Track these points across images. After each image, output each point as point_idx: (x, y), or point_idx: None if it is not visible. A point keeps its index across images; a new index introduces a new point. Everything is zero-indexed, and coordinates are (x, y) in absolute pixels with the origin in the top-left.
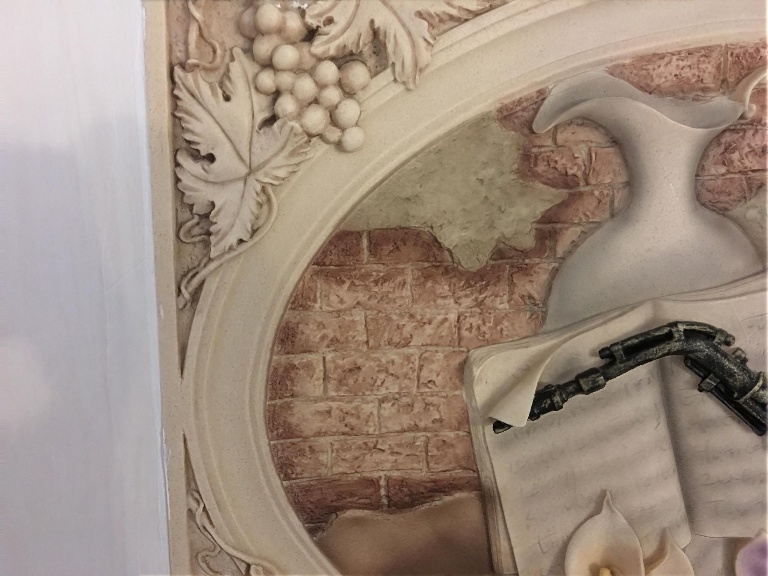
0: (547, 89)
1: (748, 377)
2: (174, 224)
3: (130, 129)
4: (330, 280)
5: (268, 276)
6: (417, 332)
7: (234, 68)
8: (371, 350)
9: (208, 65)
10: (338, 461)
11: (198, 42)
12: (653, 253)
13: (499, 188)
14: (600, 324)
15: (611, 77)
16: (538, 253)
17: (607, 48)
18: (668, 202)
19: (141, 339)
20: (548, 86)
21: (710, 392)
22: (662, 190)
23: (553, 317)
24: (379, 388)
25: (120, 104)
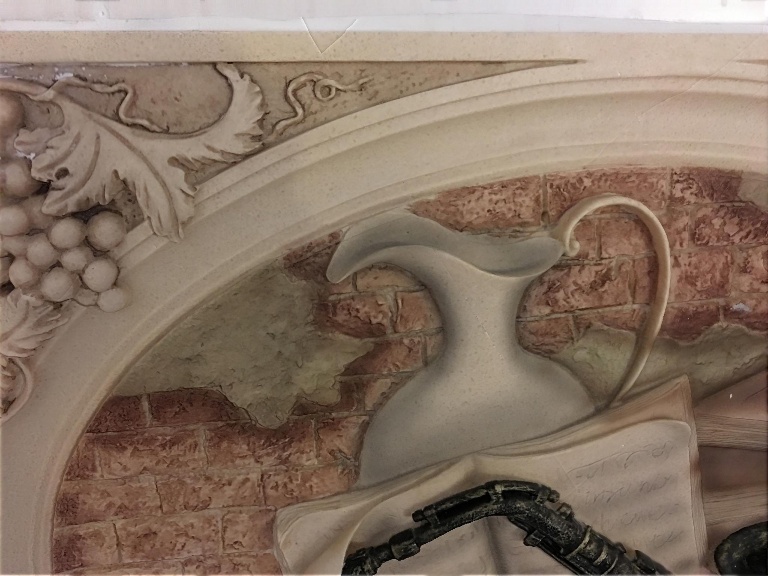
0: (341, 232)
1: (573, 535)
2: None
3: None
4: (109, 447)
5: (38, 444)
6: (216, 494)
7: None
8: (166, 515)
9: None
10: None
11: None
12: (470, 406)
13: (294, 342)
14: (413, 485)
15: (414, 216)
16: (345, 407)
17: (408, 184)
18: (484, 351)
19: None
20: (342, 229)
21: (537, 546)
22: (477, 339)
23: (366, 472)
24: (180, 552)
25: None
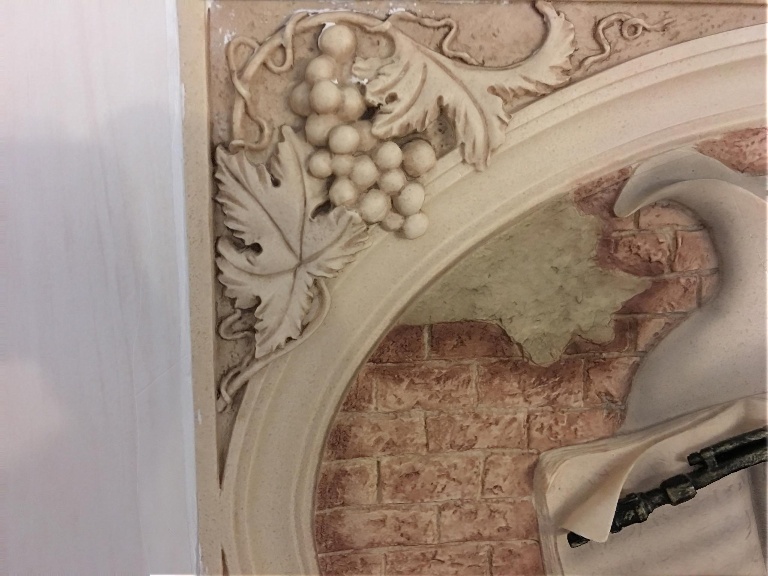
0: (630, 168)
1: None
2: (214, 320)
3: (166, 217)
4: (387, 378)
5: (317, 374)
6: (482, 433)
7: (284, 149)
8: (431, 453)
9: (254, 145)
10: (393, 574)
11: (243, 120)
12: (746, 347)
13: (576, 277)
14: (688, 427)
15: (700, 155)
16: (617, 347)
17: (696, 123)
18: (763, 292)
19: (175, 446)
20: (631, 165)
21: None
22: (756, 279)
23: (633, 416)
24: (439, 494)
25: (155, 189)
